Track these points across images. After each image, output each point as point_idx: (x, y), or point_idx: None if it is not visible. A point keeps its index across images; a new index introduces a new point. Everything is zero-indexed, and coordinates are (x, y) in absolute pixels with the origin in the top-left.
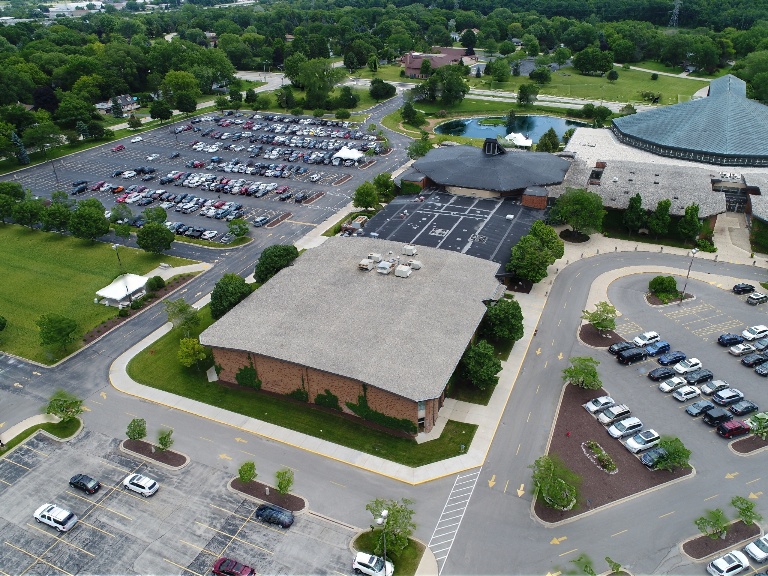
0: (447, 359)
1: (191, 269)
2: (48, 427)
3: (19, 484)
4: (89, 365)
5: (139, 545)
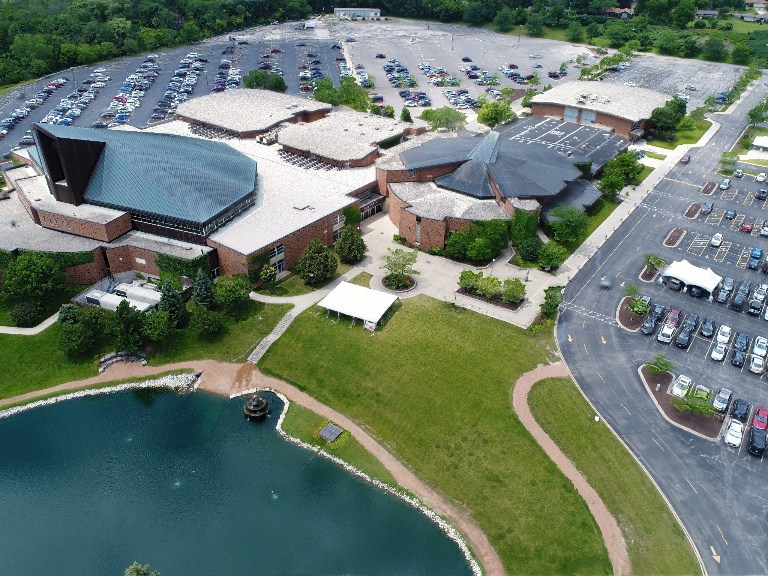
0: None
1: (740, 157)
2: None
3: None
4: None
5: None
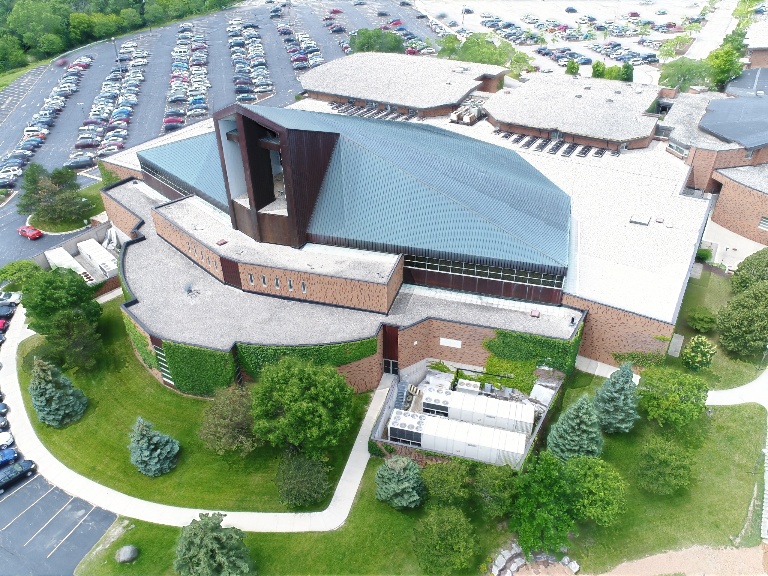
0: None
1: None
2: None
3: None
4: None
5: None
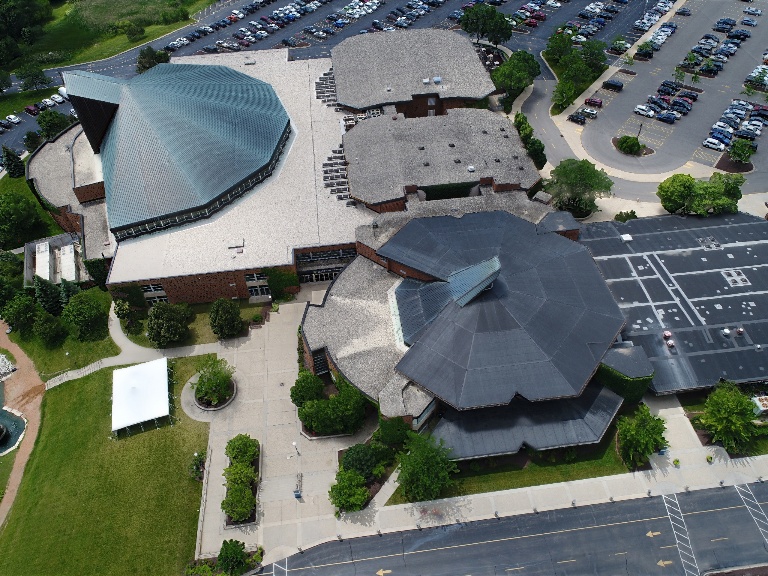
0: None
1: None
2: None
3: None
4: None
5: None
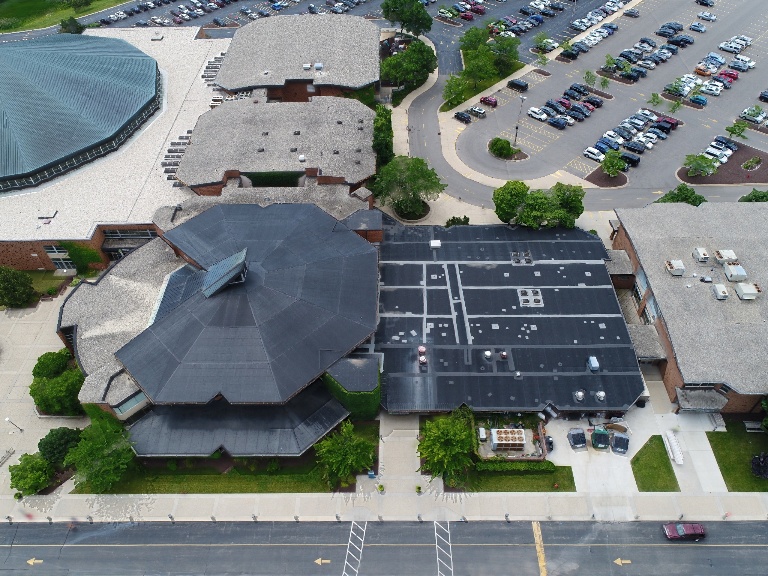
0: None
1: None
2: None
3: None
4: None
5: None
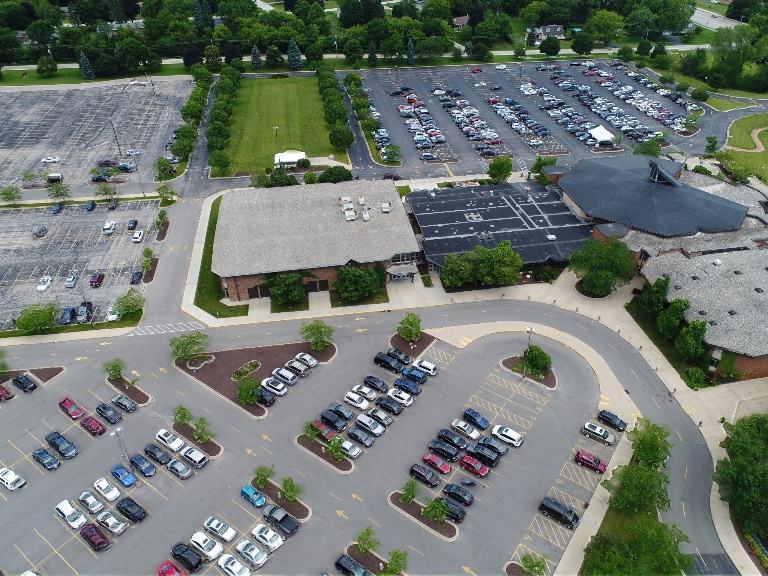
0: (262, 267)
1: None
2: (164, 199)
3: (127, 212)
4: (218, 186)
5: (105, 253)
